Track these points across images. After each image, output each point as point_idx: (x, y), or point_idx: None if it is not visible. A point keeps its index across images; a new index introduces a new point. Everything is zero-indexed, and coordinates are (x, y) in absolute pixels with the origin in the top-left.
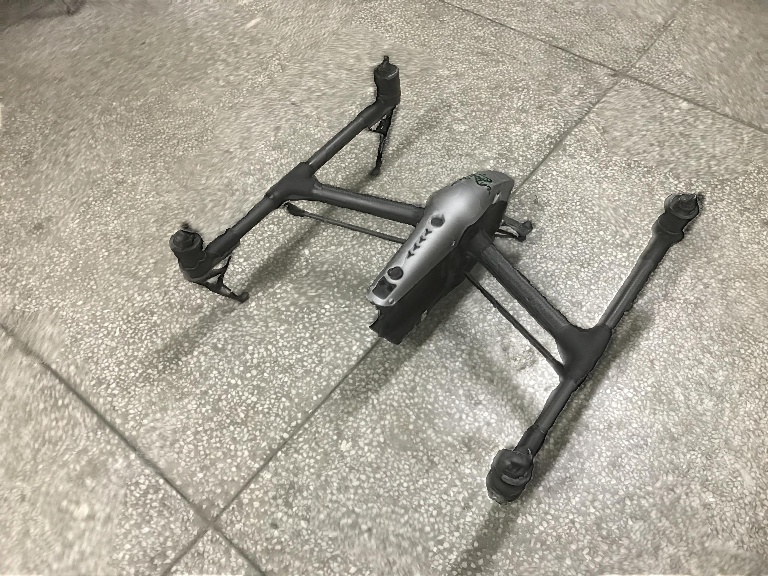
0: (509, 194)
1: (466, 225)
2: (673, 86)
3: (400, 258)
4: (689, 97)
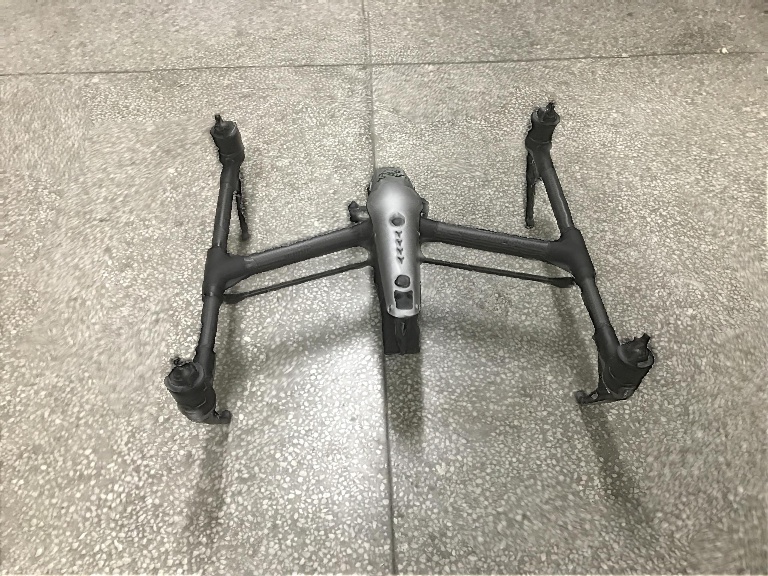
0: None
1: (418, 213)
2: (412, 58)
3: (392, 269)
4: (429, 61)
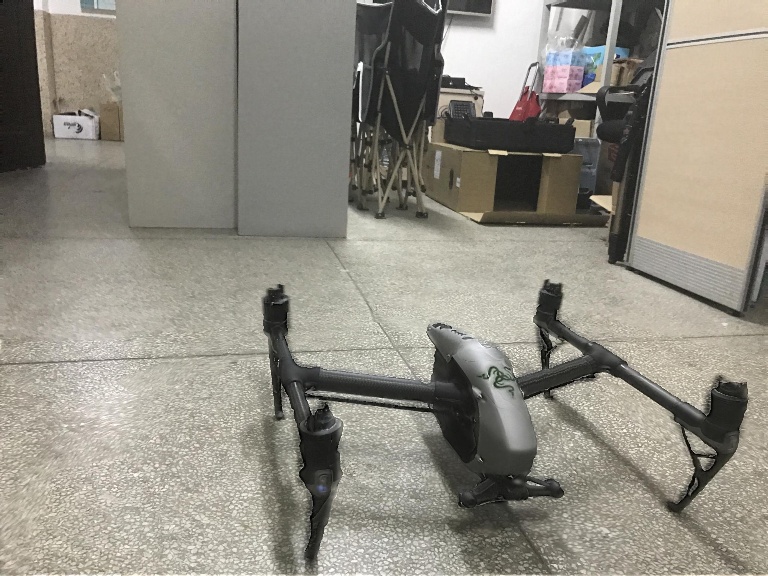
0: (494, 439)
1: None
2: None
3: None
4: None
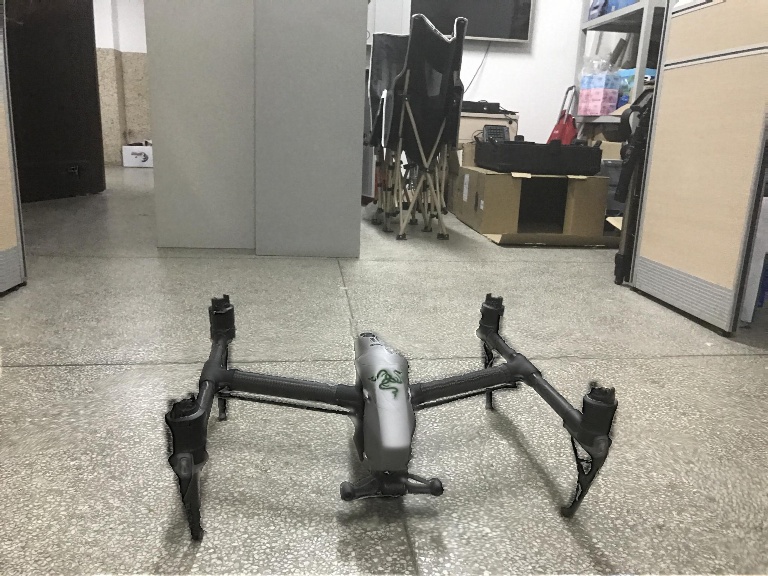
0: None
1: None
2: None
3: None
4: None
